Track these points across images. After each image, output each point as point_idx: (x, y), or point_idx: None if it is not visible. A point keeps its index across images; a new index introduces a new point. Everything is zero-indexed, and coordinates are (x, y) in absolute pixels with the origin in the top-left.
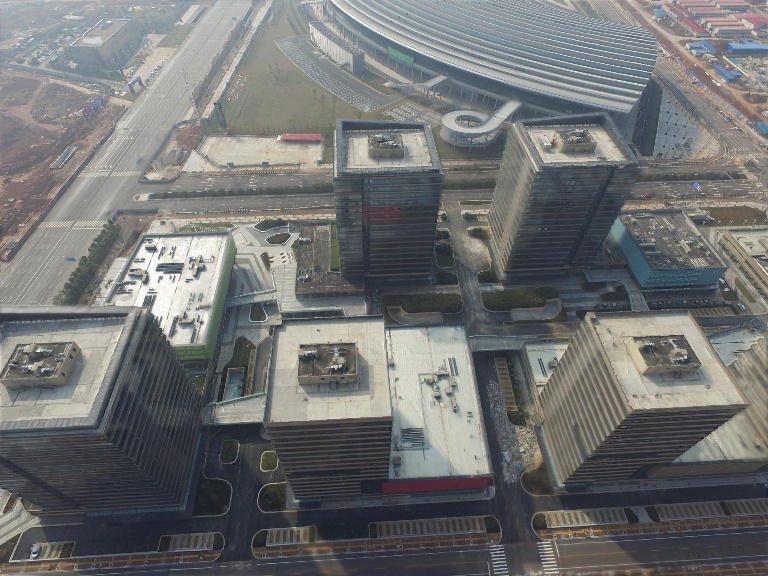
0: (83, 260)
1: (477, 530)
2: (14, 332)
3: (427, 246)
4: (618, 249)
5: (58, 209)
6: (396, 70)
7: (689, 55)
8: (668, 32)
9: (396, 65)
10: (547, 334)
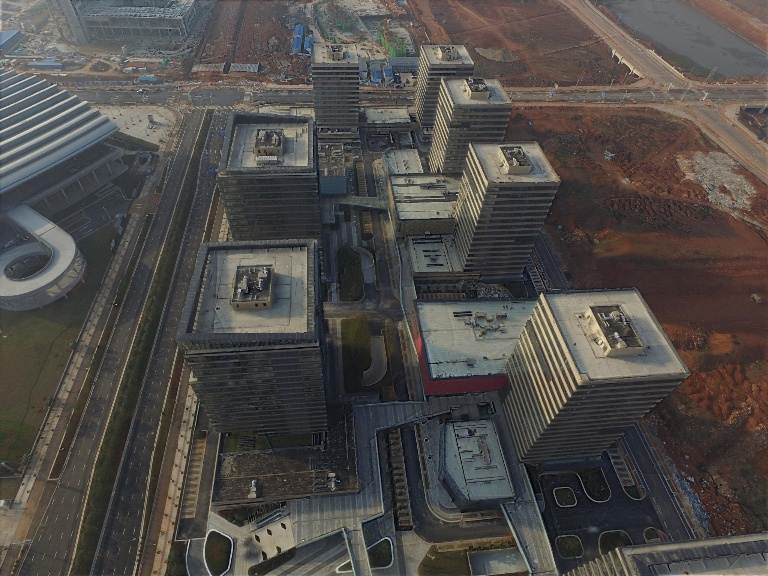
0: None
1: None
2: None
3: None
4: None
5: None
6: None
7: None
8: None
9: None
10: (388, 262)
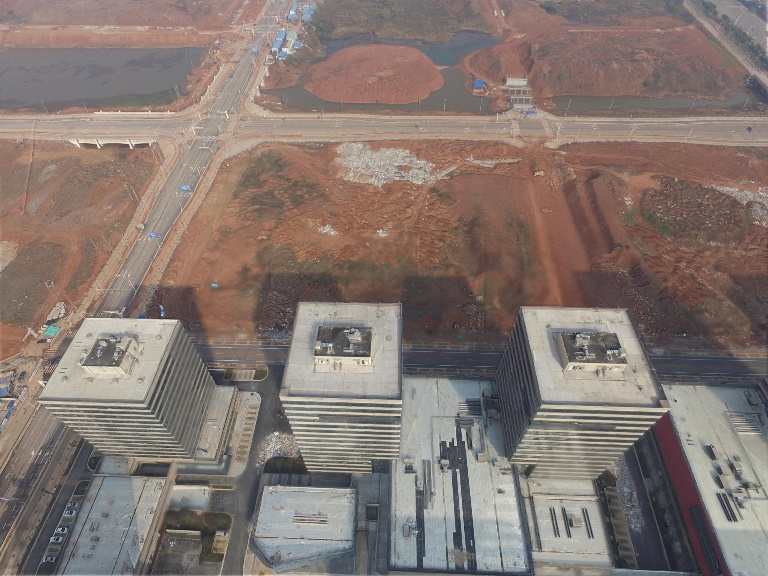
0: None
1: None
2: None
3: None
4: None
5: None
6: None
7: None
8: None
9: None
10: None
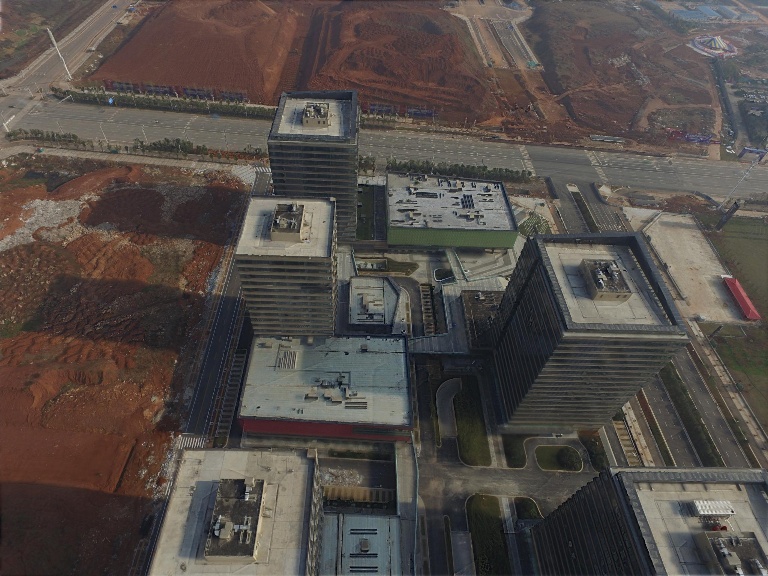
0: (483, 168)
1: (219, 429)
2: (345, 105)
3: None
4: None
5: (541, 149)
6: None
7: None
8: None
9: None
10: None
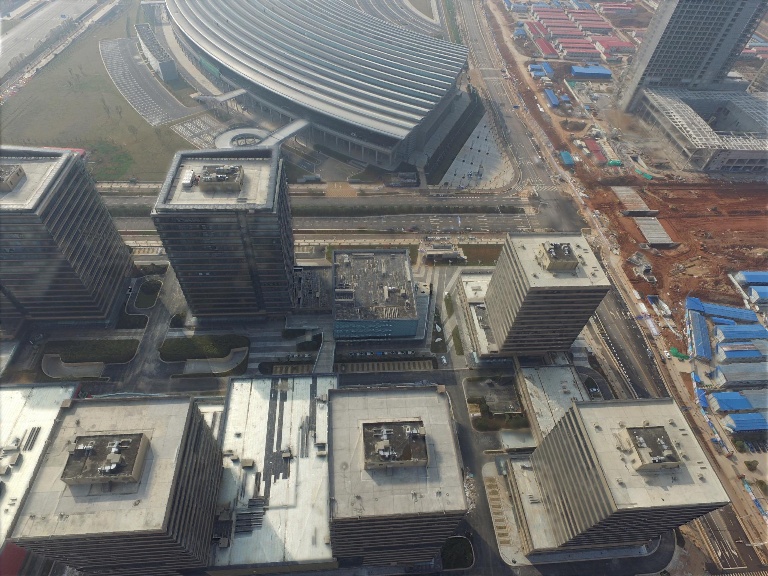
0: None
1: None
2: None
3: (79, 289)
4: (331, 292)
5: None
6: (211, 80)
7: (527, 77)
8: (518, 52)
9: (210, 75)
10: (213, 390)
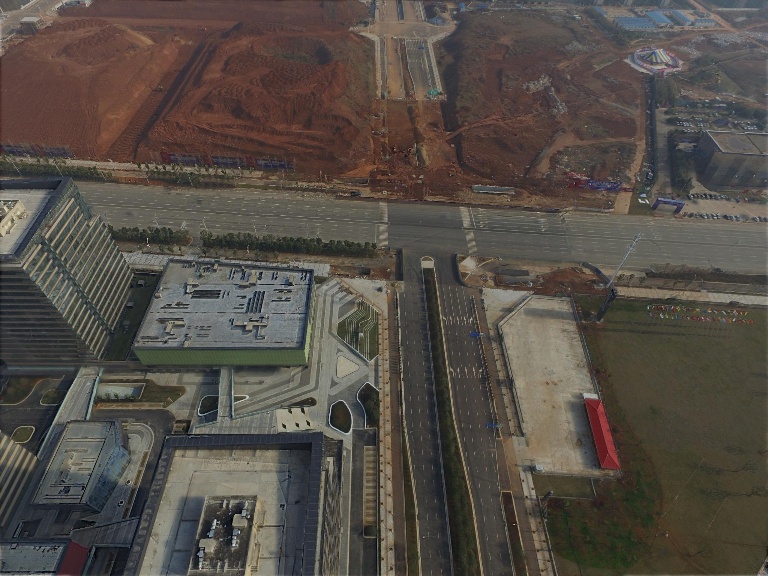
0: (317, 240)
1: None
2: None
3: None
4: None
5: (406, 207)
6: None
7: None
8: None
9: None
10: None
